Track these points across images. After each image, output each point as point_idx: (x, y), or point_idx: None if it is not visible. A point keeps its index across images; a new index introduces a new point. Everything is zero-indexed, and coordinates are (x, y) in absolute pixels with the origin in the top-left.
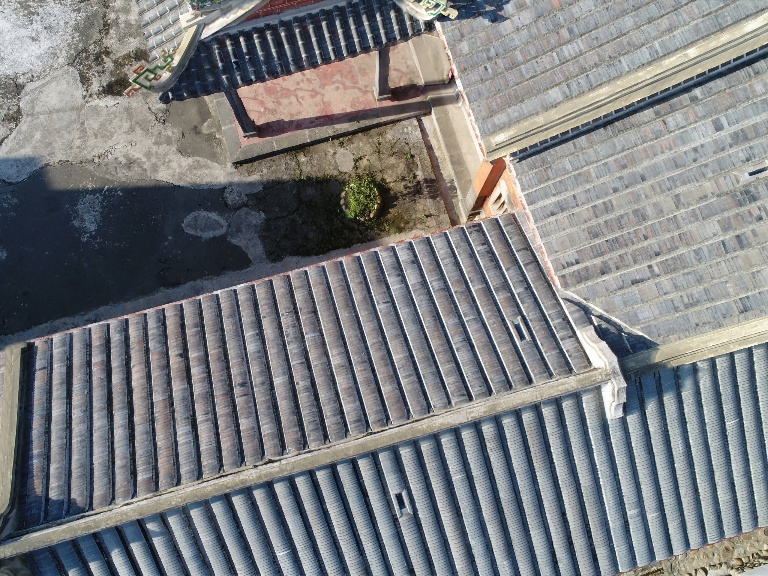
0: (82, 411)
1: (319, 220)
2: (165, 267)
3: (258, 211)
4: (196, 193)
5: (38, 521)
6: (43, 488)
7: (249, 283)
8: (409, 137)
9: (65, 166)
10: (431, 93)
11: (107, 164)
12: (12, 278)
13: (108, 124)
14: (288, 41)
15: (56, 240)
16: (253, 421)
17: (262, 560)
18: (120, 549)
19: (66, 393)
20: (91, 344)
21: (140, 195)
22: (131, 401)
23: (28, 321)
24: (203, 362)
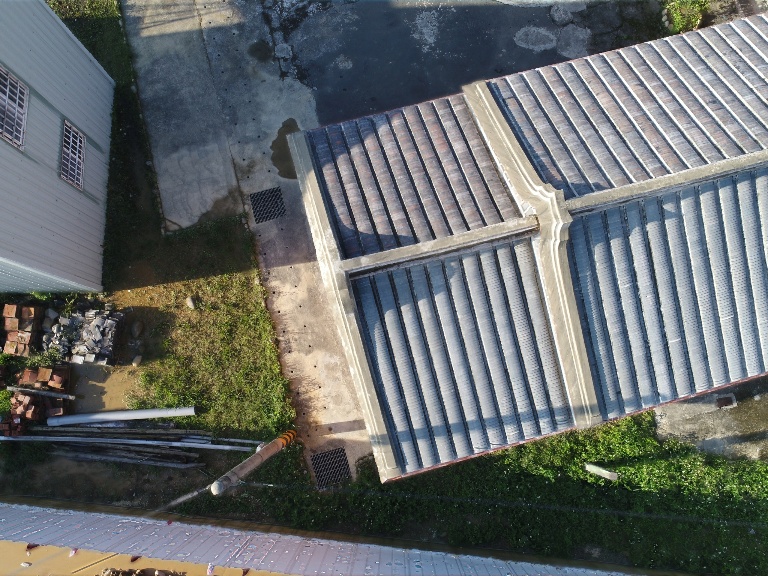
0: (566, 125)
1: (642, 36)
2: None
3: (584, 27)
4: (524, 11)
5: None
6: None
7: None
8: None
9: None
10: None
11: None
12: (359, 85)
13: None
14: None
15: (398, 51)
16: (739, 126)
17: (754, 249)
18: (640, 228)
19: (543, 114)
20: (545, 81)
21: (472, 12)
22: (607, 119)
23: None
24: (665, 89)
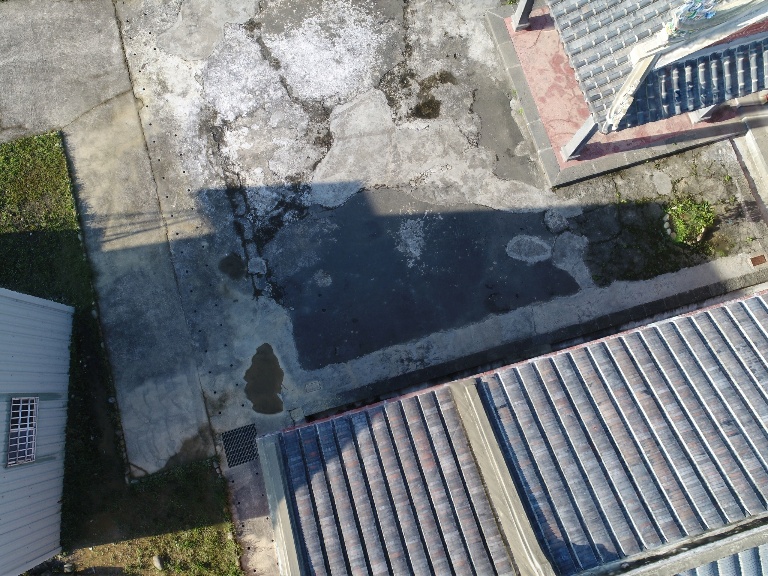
0: (566, 451)
1: (643, 244)
2: (493, 293)
3: (580, 235)
4: (516, 217)
5: (574, 568)
6: (560, 533)
7: (682, 316)
8: (724, 159)
9: (382, 190)
10: (748, 114)
11: (424, 188)
12: (339, 305)
13: (421, 147)
14: (730, 70)
15: (381, 266)
16: (758, 461)
17: None
18: None
19: (540, 432)
20: (541, 380)
21: (461, 219)
22: (611, 440)
23: (360, 349)
24: (674, 399)
